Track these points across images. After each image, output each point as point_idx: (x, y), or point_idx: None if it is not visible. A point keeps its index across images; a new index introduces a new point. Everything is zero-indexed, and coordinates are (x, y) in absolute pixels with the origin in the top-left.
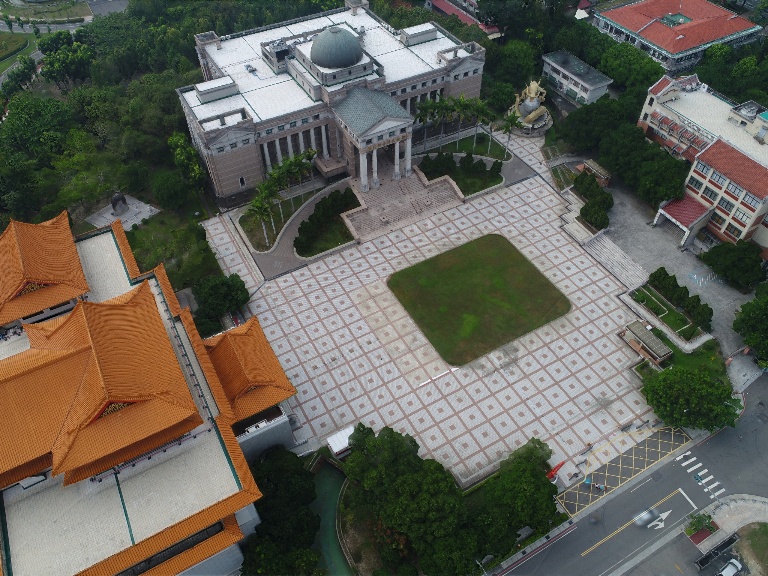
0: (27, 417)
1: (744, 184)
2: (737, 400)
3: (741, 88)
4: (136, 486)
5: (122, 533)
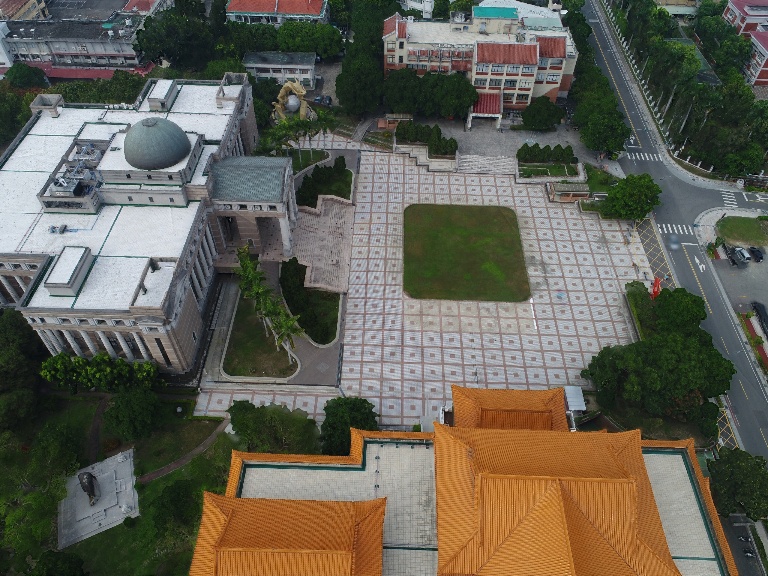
0: None
1: (519, 61)
2: None
3: None
4: None
5: (700, 567)
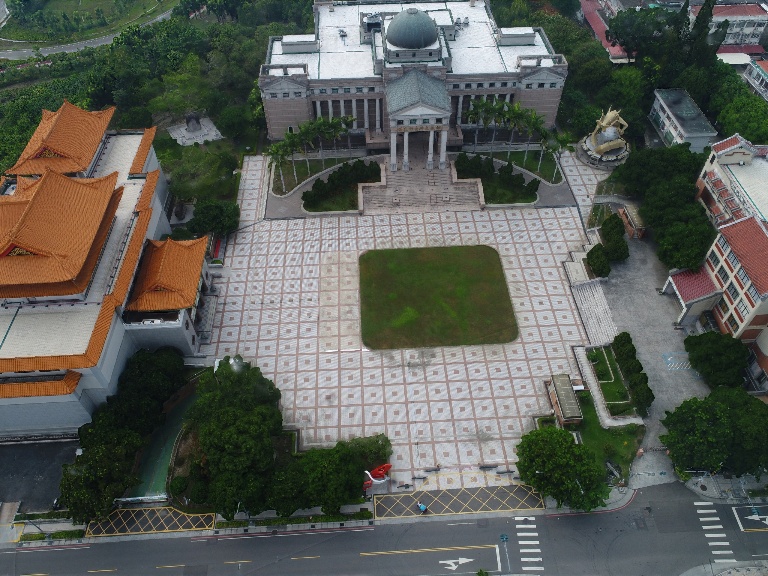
0: None
1: (751, 272)
2: (608, 489)
3: None
4: (25, 321)
5: None
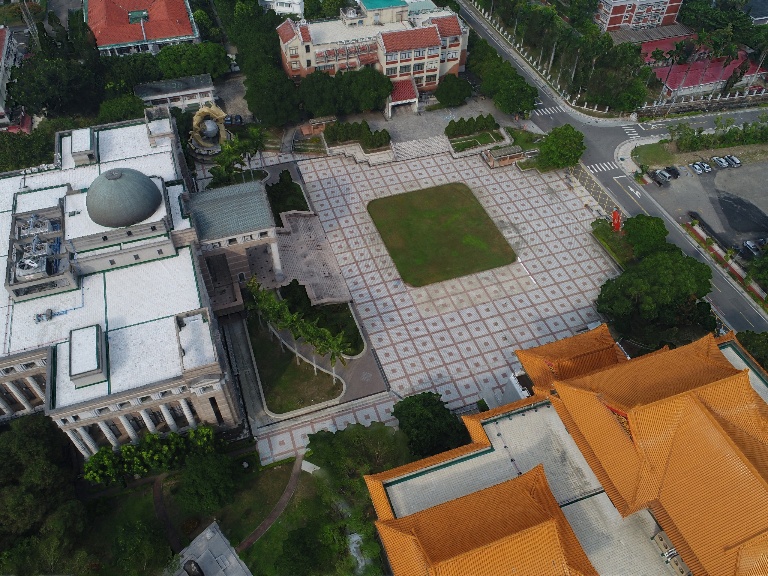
0: (763, 465)
1: (424, 45)
2: None
3: (273, 21)
4: None
5: None
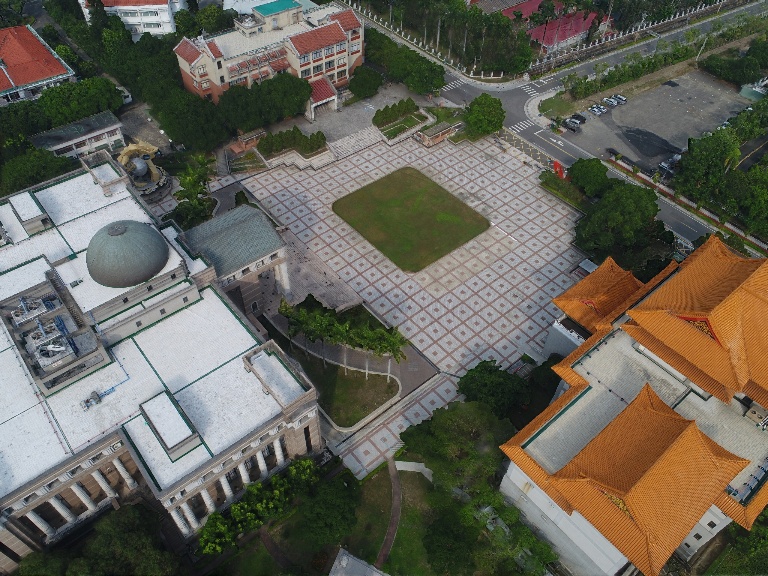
0: None
1: (332, 42)
2: None
3: (153, 44)
4: None
5: None
